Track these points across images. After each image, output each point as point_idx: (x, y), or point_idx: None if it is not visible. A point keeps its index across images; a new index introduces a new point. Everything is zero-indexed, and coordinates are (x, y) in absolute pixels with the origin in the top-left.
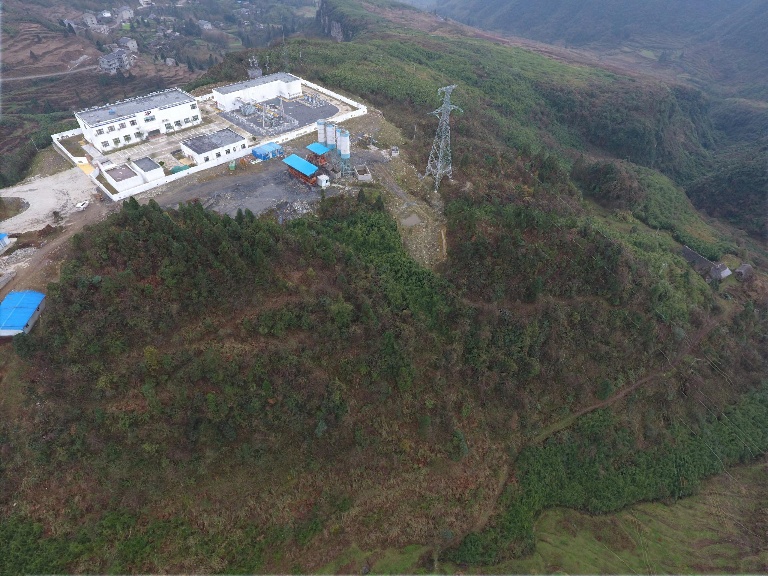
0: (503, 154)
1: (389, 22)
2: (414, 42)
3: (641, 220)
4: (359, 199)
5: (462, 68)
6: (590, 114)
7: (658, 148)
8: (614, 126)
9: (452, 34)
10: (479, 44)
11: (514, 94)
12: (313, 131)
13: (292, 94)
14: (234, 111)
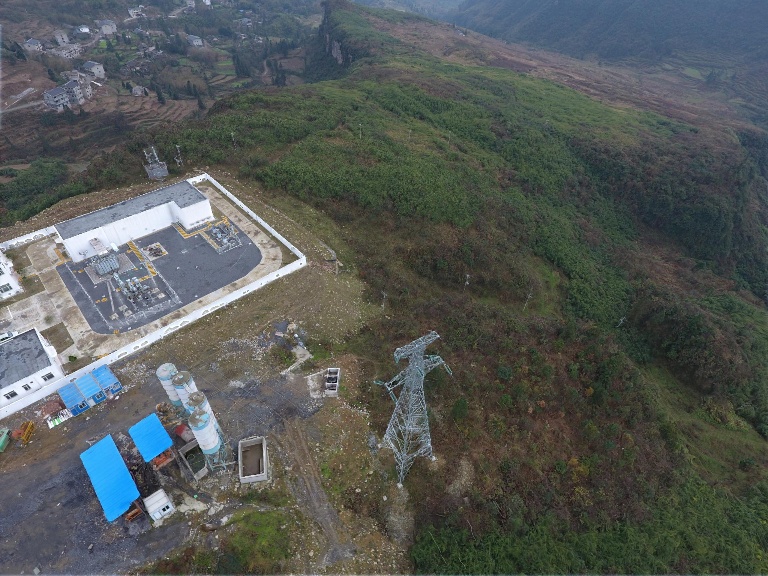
0: (531, 352)
1: (397, 43)
2: (417, 85)
3: (748, 419)
4: (219, 573)
5: (477, 124)
6: (644, 185)
7: (735, 233)
8: (677, 204)
9: (470, 59)
10: (501, 78)
11: (544, 161)
12: (201, 317)
13: (195, 222)
14: (88, 261)
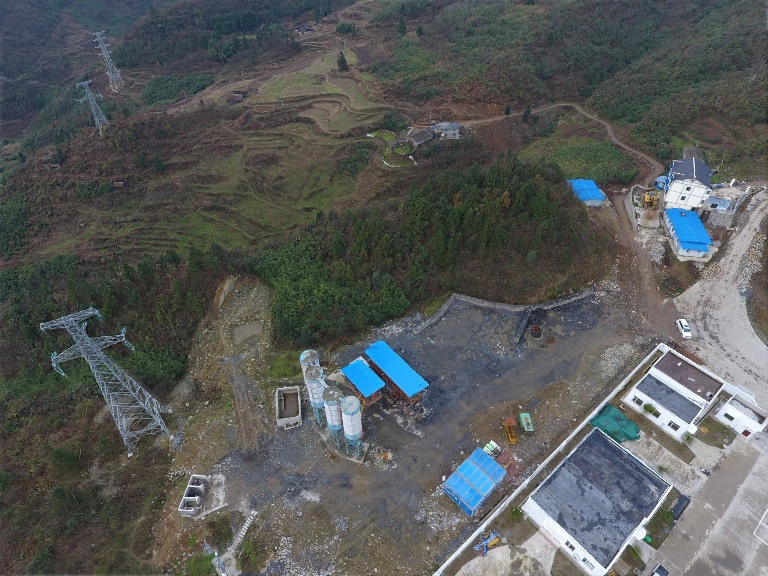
0: None
1: None
2: None
3: None
4: None
5: None
6: None
7: None
8: None
9: None
10: None
11: None
12: None
13: None
14: None
